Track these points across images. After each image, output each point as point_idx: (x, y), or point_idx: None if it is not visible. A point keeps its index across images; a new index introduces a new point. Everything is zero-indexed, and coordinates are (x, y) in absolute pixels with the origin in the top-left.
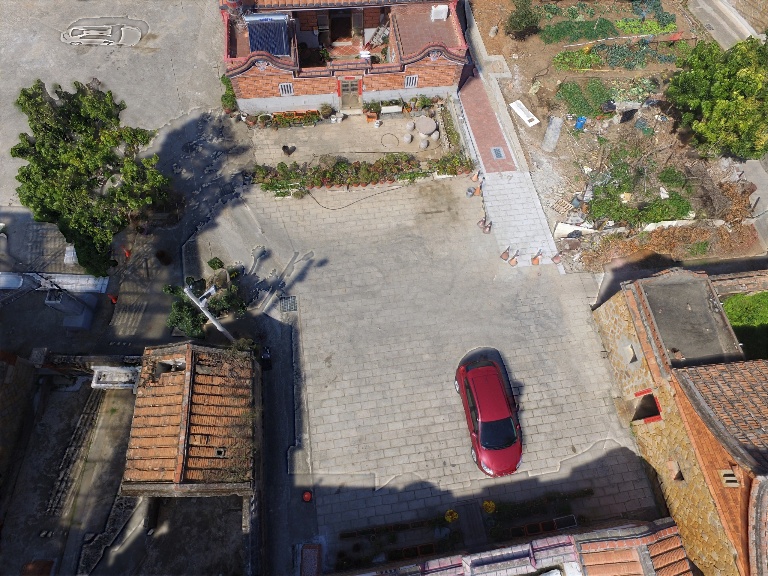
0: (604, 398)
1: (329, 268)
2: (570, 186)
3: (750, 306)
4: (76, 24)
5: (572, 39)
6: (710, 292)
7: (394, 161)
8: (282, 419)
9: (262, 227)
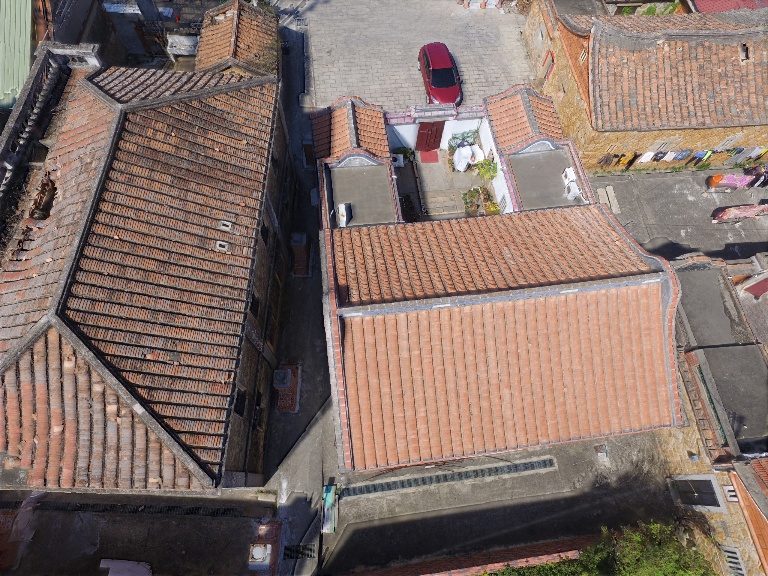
0: (524, 80)
1: (331, 4)
2: None
3: None
4: None
5: None
6: None
7: None
8: (296, 80)
9: None
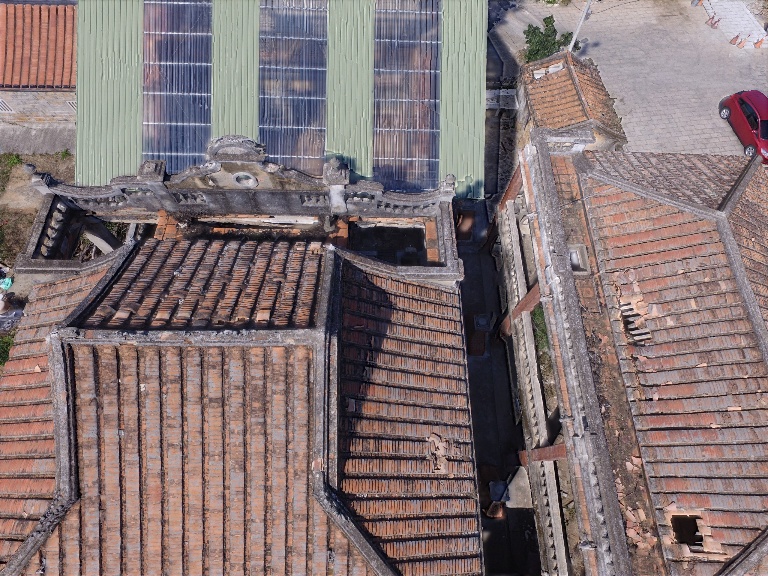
0: None
1: (603, 48)
2: (767, 2)
3: None
4: None
5: None
6: None
7: None
8: None
9: (543, 23)
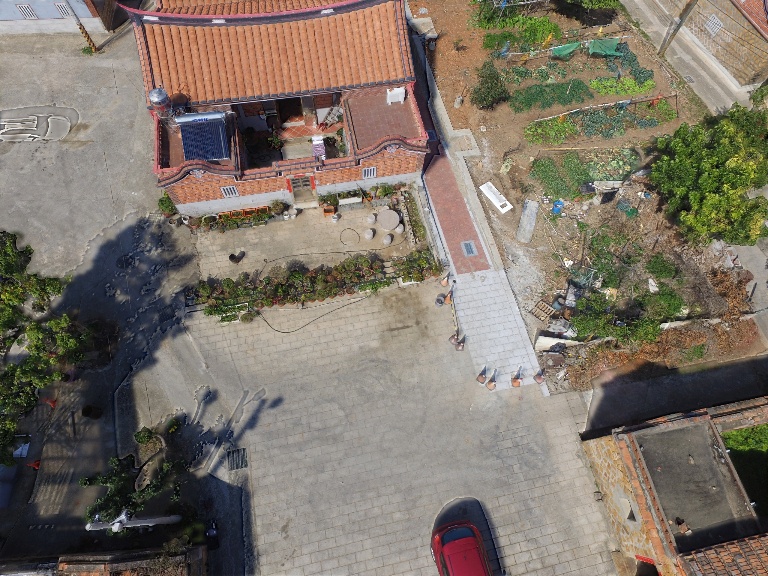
0: (601, 553)
1: (283, 409)
2: (550, 283)
3: (756, 427)
4: None
5: (544, 106)
6: (714, 437)
7: (354, 267)
8: None
9: (206, 361)
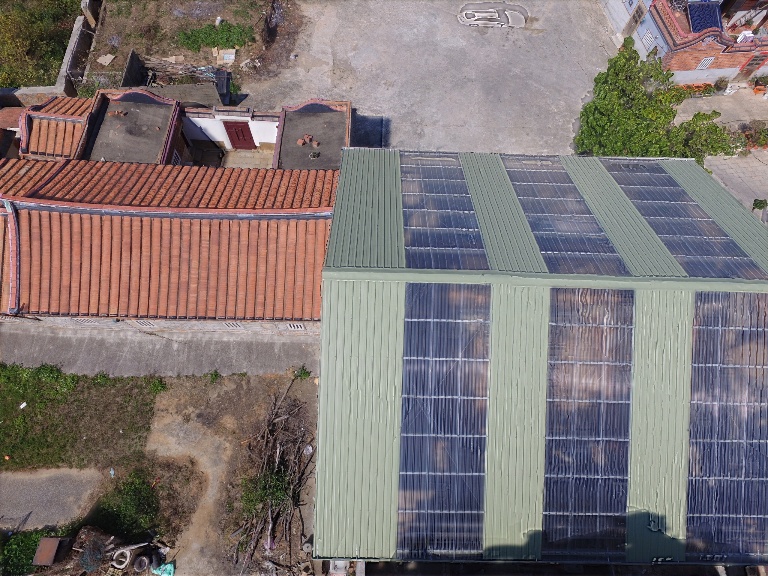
0: None
1: None
2: None
3: None
4: (465, 8)
5: None
6: None
7: None
8: None
9: (724, 181)
